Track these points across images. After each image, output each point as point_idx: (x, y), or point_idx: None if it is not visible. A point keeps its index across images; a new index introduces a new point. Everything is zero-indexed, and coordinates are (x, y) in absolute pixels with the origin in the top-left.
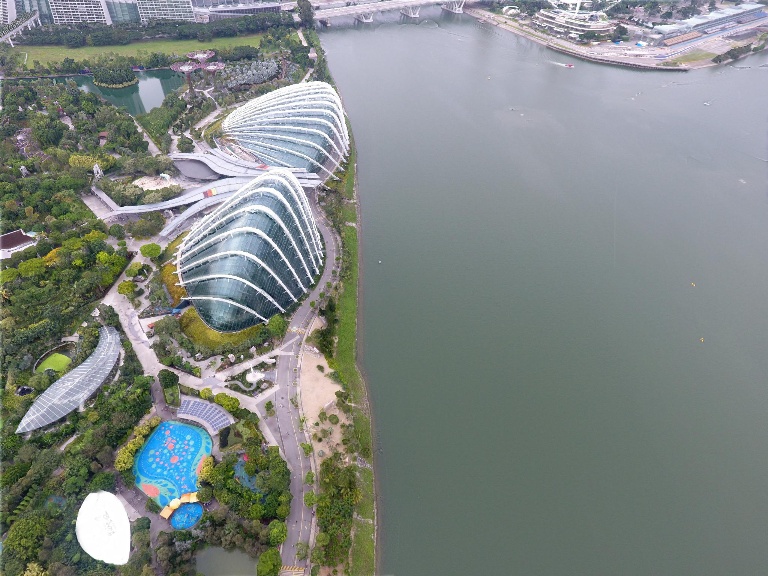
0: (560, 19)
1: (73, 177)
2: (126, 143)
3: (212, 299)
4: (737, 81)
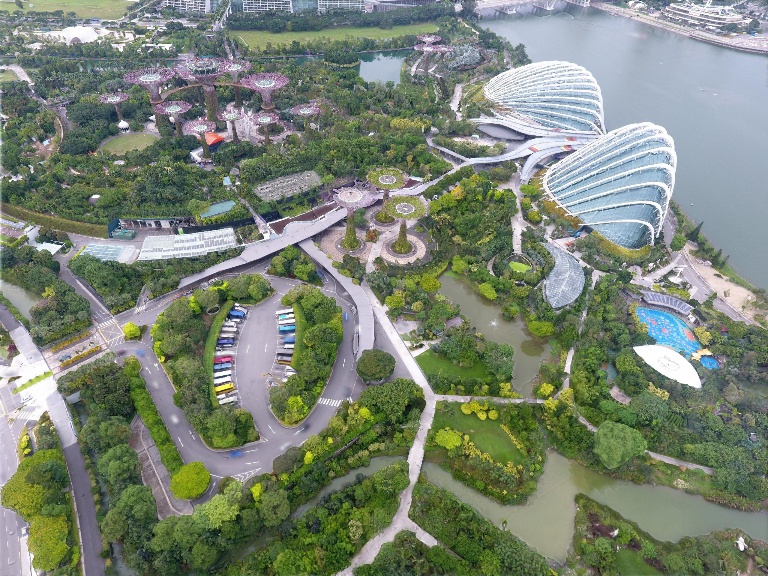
0: (694, 12)
1: (415, 135)
2: (423, 110)
3: (627, 221)
4: None
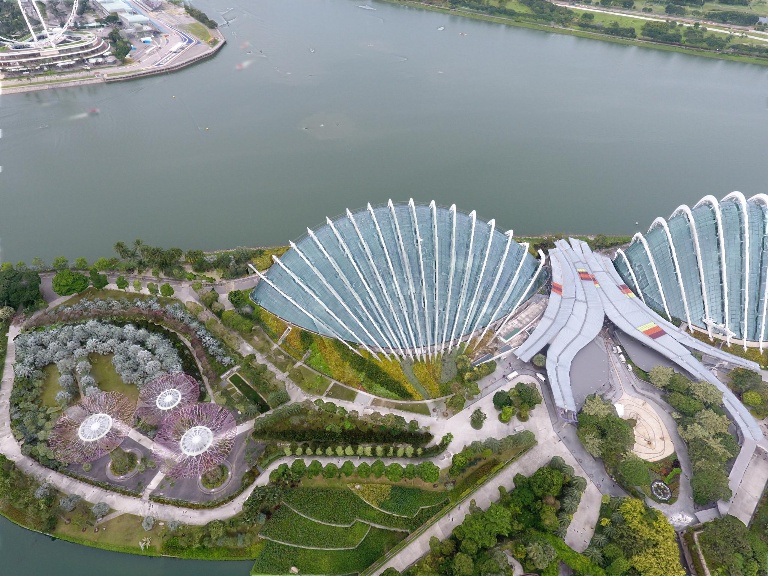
0: (49, 52)
1: None
2: (554, 506)
3: None
4: (280, 30)
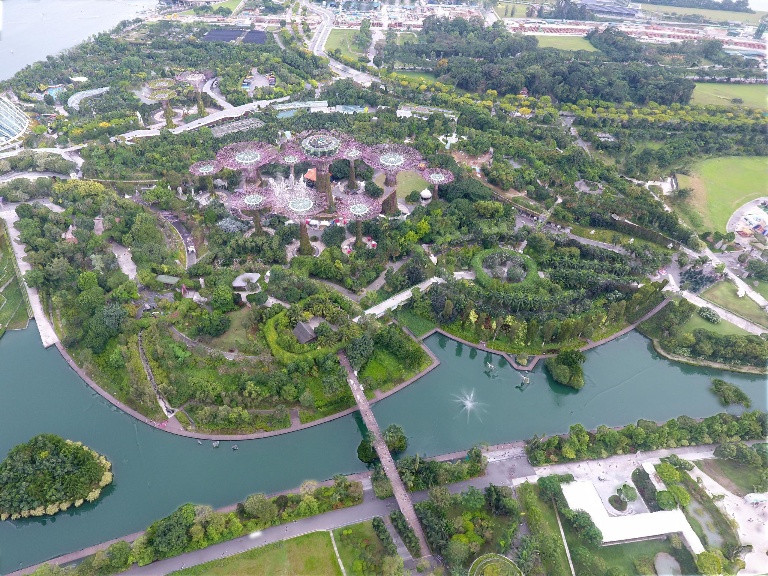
0: None
1: None
2: None
3: (7, 100)
4: None
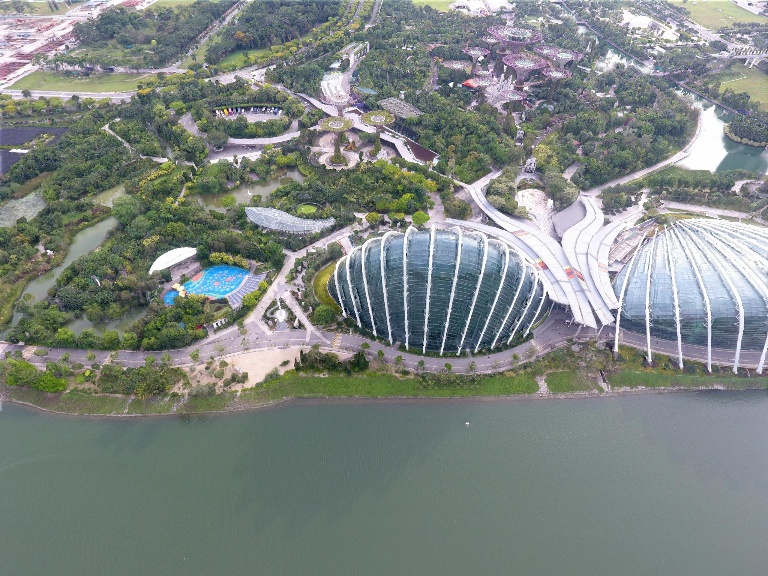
0: None
1: None
2: None
3: (343, 259)
4: None
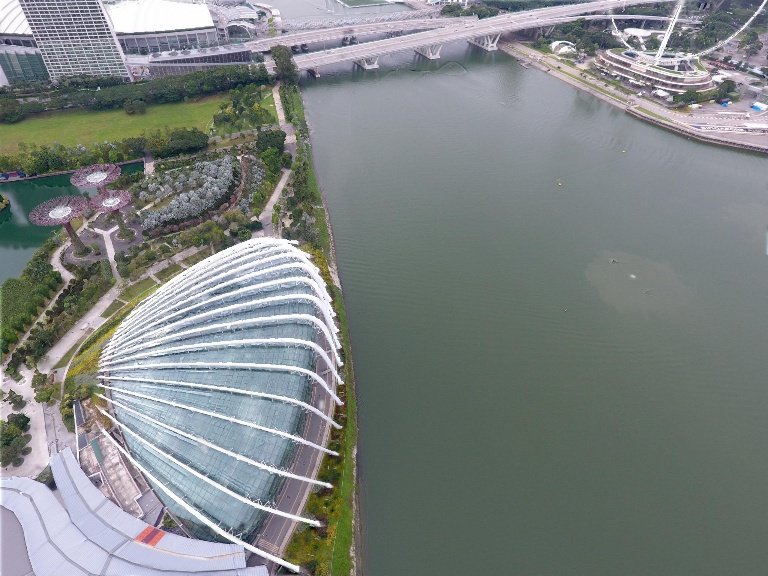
0: (638, 67)
1: None
2: None
3: None
4: None
